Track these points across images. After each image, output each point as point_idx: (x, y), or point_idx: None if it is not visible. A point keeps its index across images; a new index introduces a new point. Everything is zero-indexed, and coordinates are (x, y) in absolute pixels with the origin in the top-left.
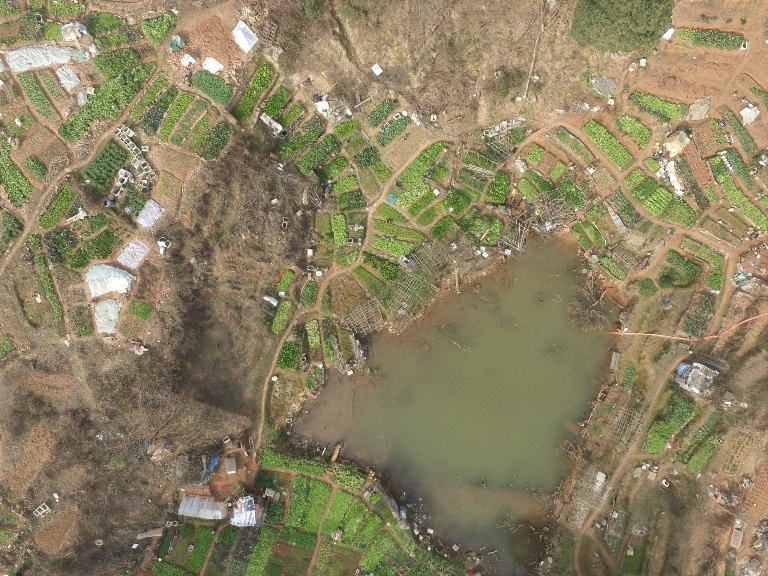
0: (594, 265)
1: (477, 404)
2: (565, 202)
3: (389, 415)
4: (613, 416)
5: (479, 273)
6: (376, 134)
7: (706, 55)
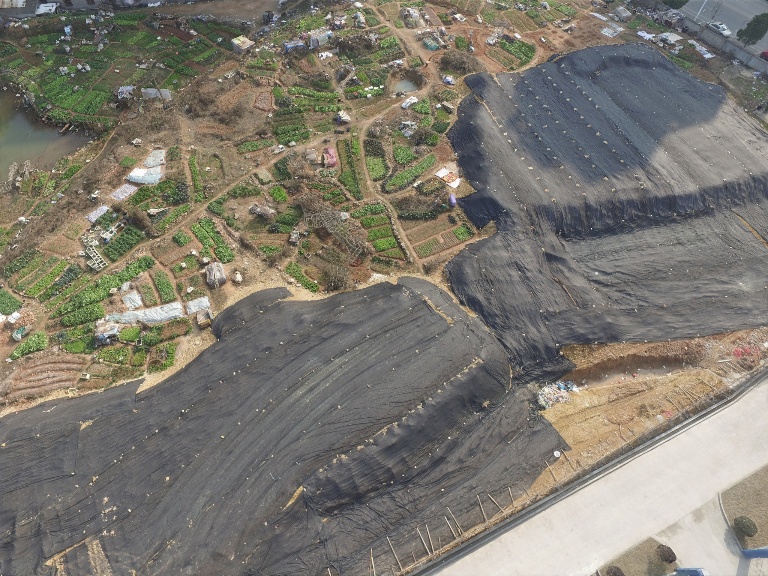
0: None
1: None
2: None
3: (18, 149)
4: None
5: None
6: None
7: None
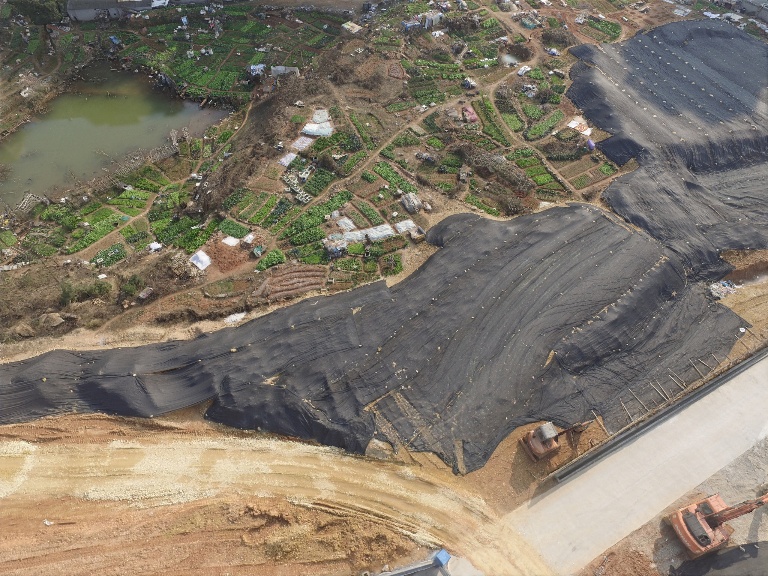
0: None
1: (101, 128)
2: None
3: (165, 121)
4: (2, 123)
5: None
6: None
7: None
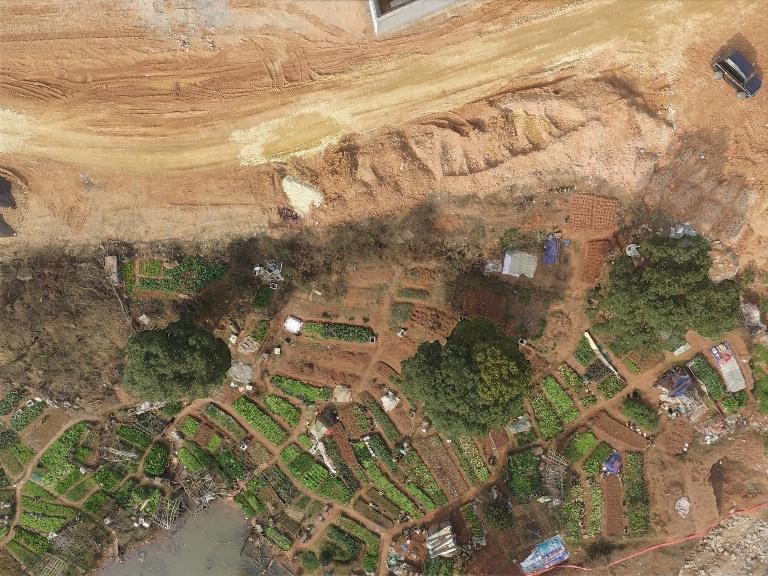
0: (260, 534)
1: None
2: (213, 482)
3: None
4: None
5: (141, 542)
6: (11, 419)
7: (339, 346)
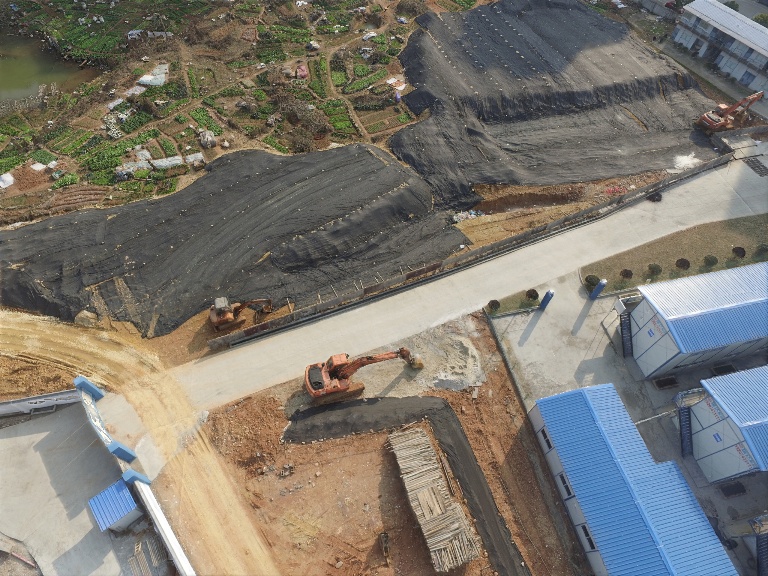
0: None
1: None
2: None
3: (44, 79)
4: None
5: None
6: None
7: None
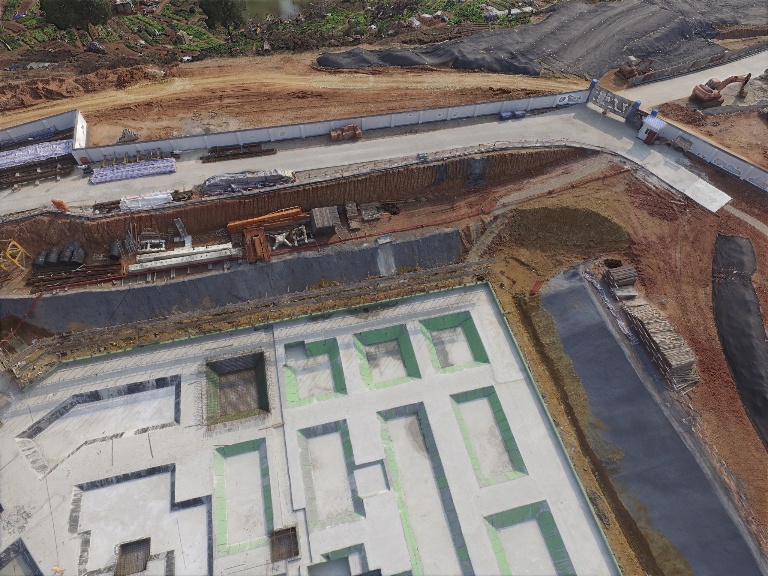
0: None
1: None
2: None
3: None
4: None
5: None
6: None
7: None
